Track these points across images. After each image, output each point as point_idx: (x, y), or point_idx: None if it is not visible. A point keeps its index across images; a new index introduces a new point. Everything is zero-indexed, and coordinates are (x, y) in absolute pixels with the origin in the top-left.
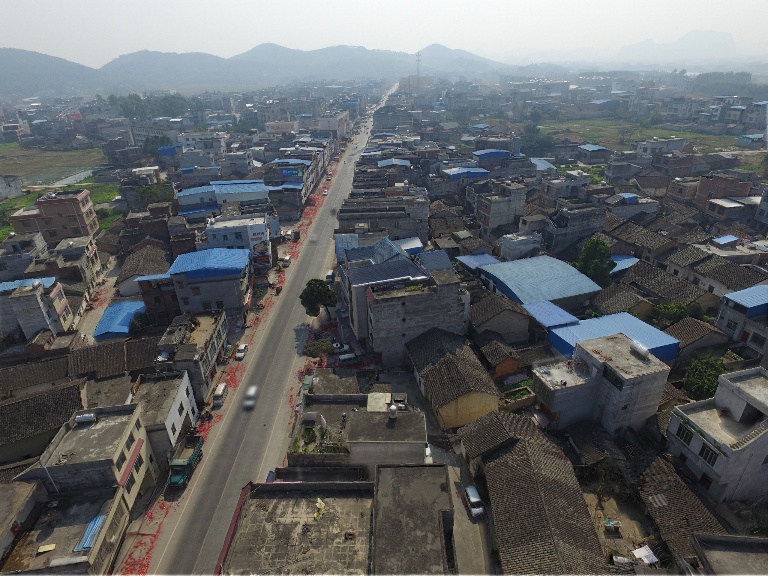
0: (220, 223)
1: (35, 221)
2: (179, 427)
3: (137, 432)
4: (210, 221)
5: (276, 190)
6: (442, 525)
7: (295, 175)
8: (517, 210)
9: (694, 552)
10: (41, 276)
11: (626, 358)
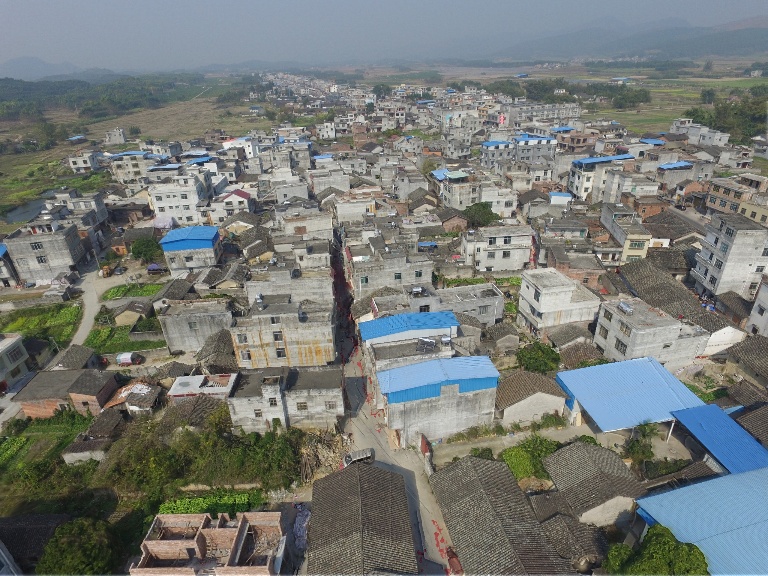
0: None
1: None
2: None
3: None
4: None
5: None
6: None
7: None
8: None
9: (594, 292)
10: None
11: (637, 309)
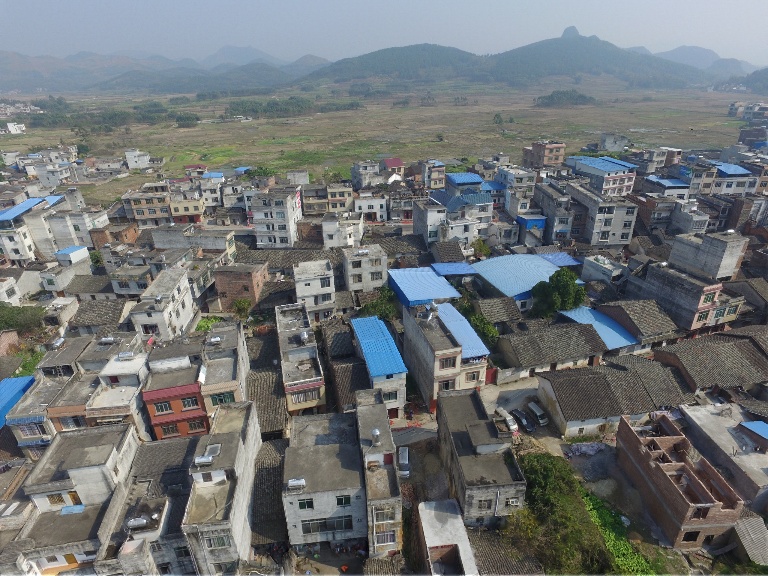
0: (515, 169)
1: (529, 154)
2: (365, 211)
3: (347, 196)
4: (512, 166)
5: (652, 181)
6: (267, 198)
7: (687, 175)
8: (708, 267)
9: None
10: (470, 171)
11: None
